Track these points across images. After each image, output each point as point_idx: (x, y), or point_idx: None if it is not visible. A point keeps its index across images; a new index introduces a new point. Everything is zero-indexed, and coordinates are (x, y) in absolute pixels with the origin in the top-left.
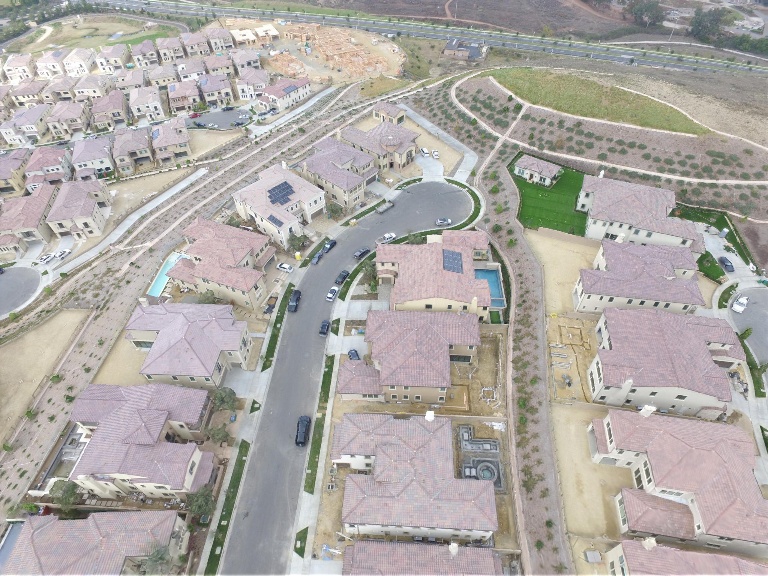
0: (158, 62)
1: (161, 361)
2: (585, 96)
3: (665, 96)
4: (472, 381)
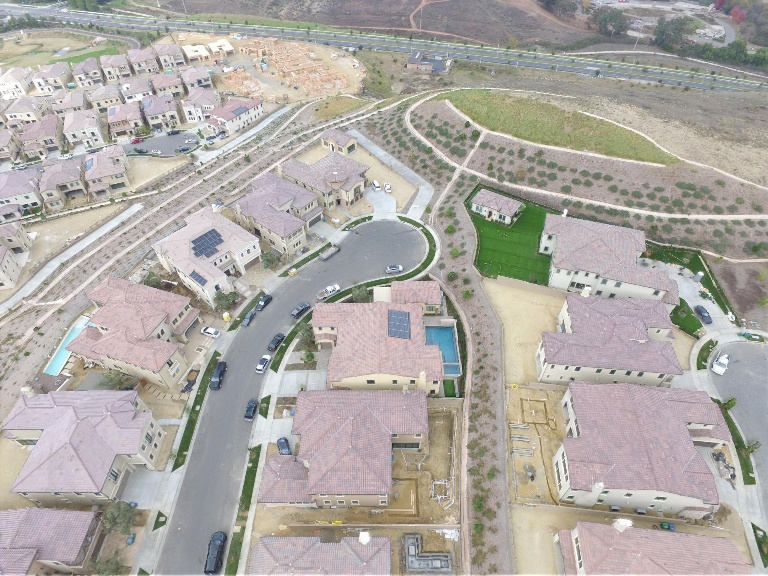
0: (102, 81)
1: (38, 474)
2: (546, 122)
3: (630, 121)
4: (421, 473)
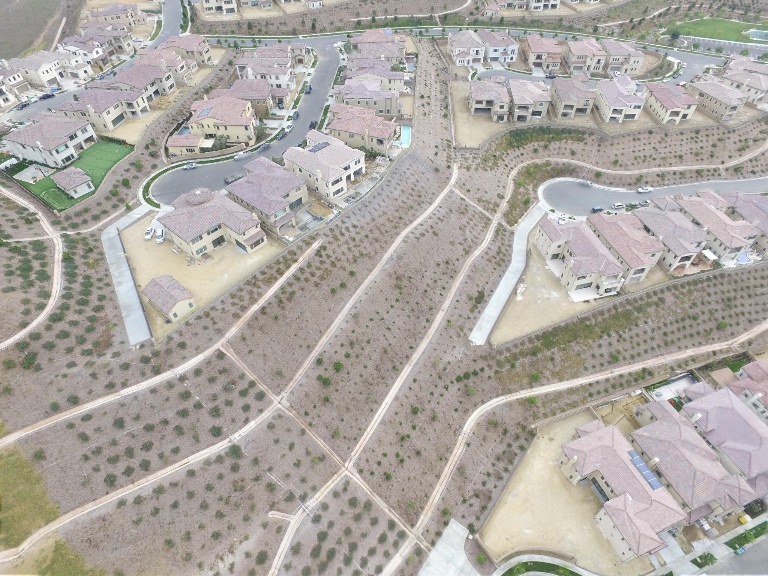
0: None
1: None
2: None
3: None
4: None
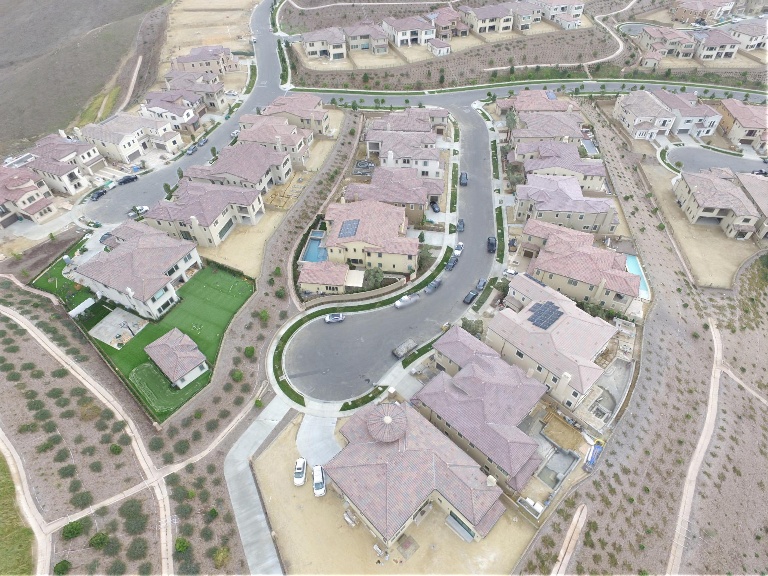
0: None
1: None
2: None
3: None
4: None
